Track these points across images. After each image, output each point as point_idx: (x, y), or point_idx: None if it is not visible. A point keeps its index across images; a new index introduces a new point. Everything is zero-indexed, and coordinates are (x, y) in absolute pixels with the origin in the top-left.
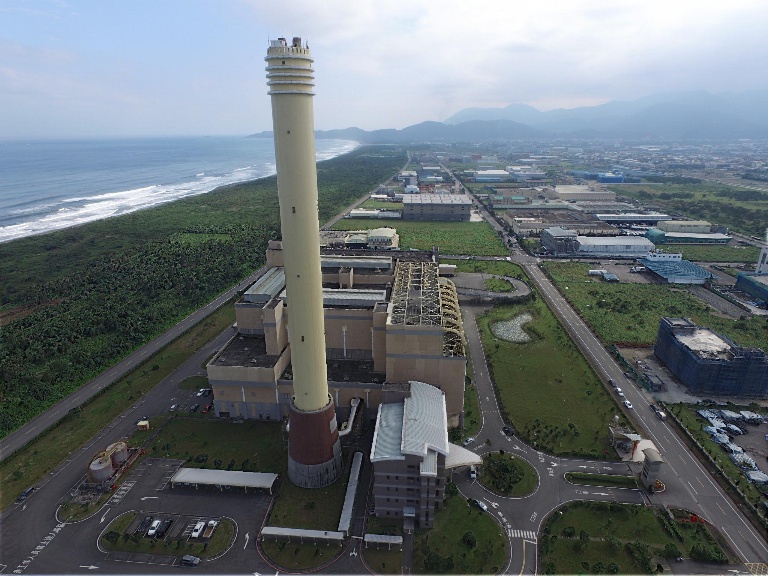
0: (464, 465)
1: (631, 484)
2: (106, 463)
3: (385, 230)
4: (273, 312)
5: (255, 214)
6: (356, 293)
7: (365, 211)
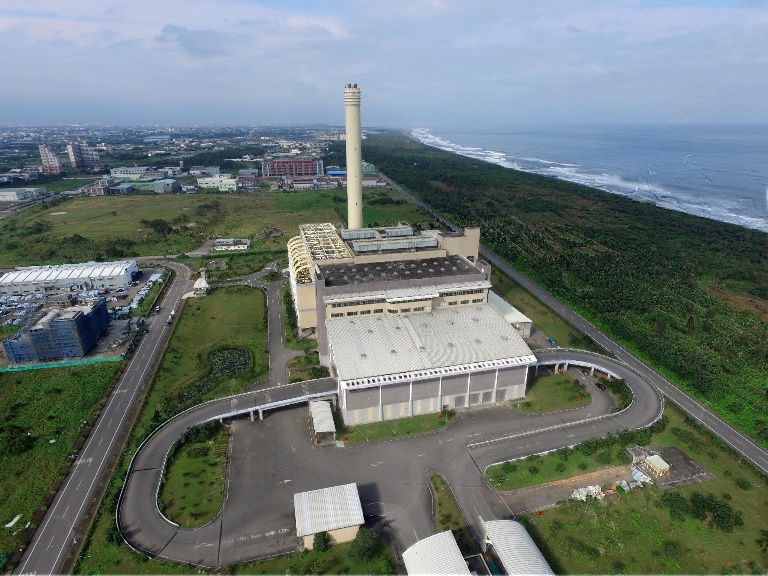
0: None
1: None
2: None
3: None
4: None
5: None
6: None
7: None
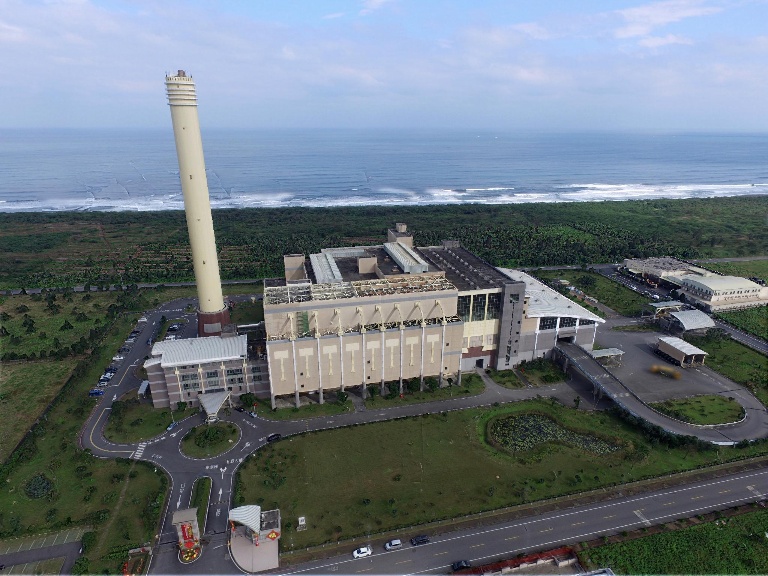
0: (202, 404)
1: None
2: None
3: (734, 280)
4: None
5: (675, 226)
6: None
7: None
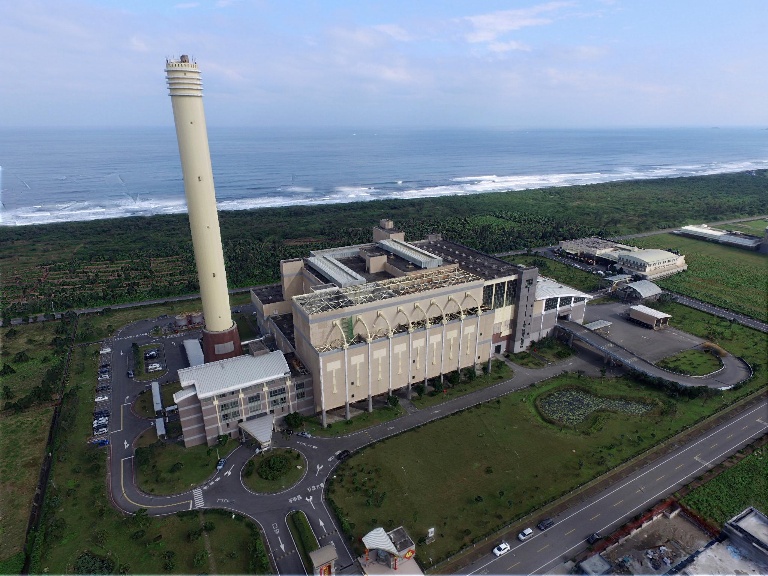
0: (250, 433)
1: (312, 569)
2: (181, 317)
3: (657, 253)
4: (282, 265)
5: (577, 211)
6: (347, 274)
7: (707, 230)
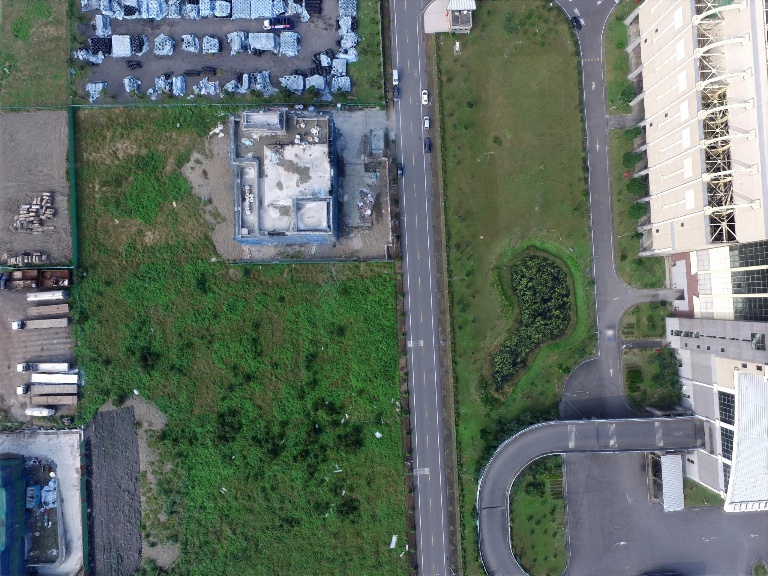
0: None
1: None
2: None
3: None
4: None
5: None
6: None
7: None
